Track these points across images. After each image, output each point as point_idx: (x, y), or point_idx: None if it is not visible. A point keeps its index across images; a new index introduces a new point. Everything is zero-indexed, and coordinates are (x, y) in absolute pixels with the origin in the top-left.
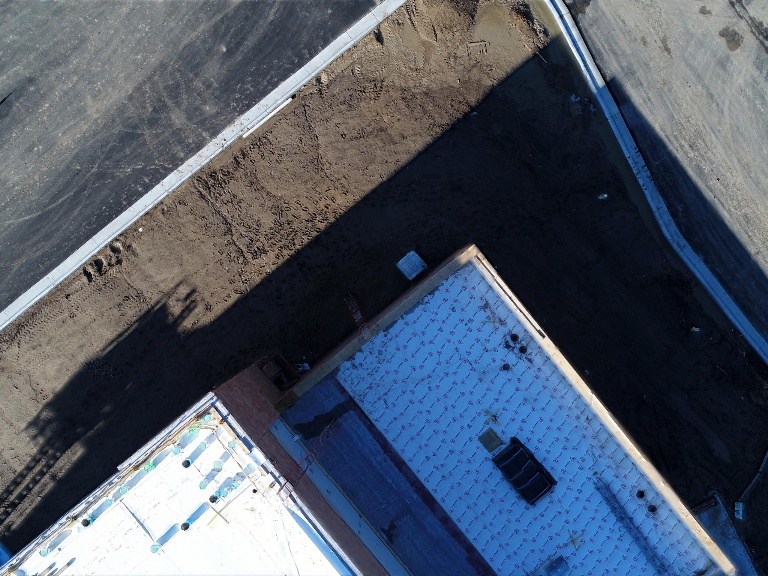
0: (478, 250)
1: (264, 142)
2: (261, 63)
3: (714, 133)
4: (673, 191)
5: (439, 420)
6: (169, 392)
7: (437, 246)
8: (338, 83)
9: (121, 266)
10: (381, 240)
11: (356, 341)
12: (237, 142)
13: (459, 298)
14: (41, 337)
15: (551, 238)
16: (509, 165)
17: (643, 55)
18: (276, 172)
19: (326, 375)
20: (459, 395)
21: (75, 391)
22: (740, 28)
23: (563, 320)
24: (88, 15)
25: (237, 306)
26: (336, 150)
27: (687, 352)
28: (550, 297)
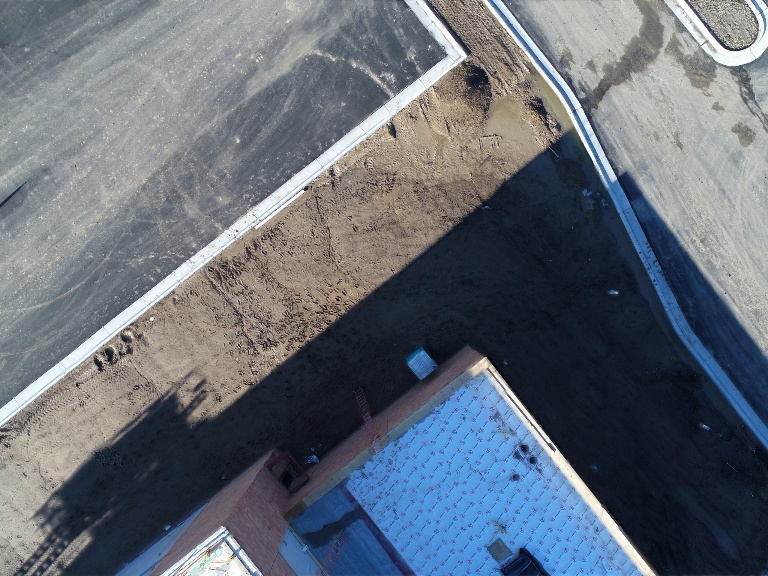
0: (490, 363)
1: (276, 233)
2: (274, 155)
3: (726, 229)
4: (684, 286)
5: (448, 530)
6: (177, 482)
7: (447, 340)
8: (350, 175)
9: (132, 355)
10: (391, 333)
11: (366, 452)
12: (249, 233)
13: (470, 408)
14: (51, 425)
15: (561, 333)
16: (520, 259)
17: (655, 150)
18: (287, 264)
19: (336, 484)
20: (469, 505)
21: (84, 480)
22: (752, 124)
23: (573, 415)
24: (103, 106)
25: (247, 397)
26: (348, 243)
27: (697, 449)
28: (560, 392)
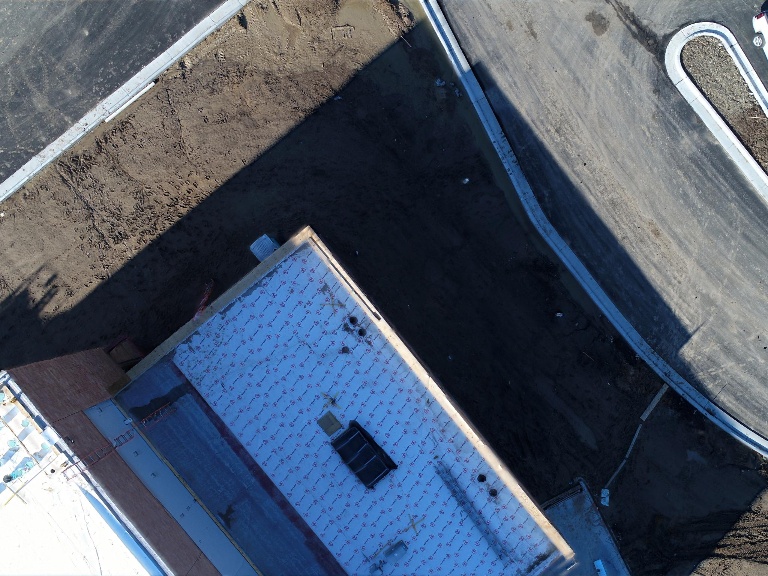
0: (313, 231)
1: (126, 126)
2: (124, 47)
3: (580, 118)
4: (539, 176)
5: (277, 403)
6: None
7: None
8: (201, 67)
9: None
10: (243, 225)
11: (190, 323)
12: (100, 127)
13: (298, 280)
14: None
15: (415, 223)
16: (373, 150)
17: (509, 39)
18: (138, 157)
19: (162, 358)
20: (298, 378)
21: None
22: (606, 13)
23: (428, 306)
24: None
25: (98, 291)
26: (198, 134)
27: (553, 338)
28: (414, 282)
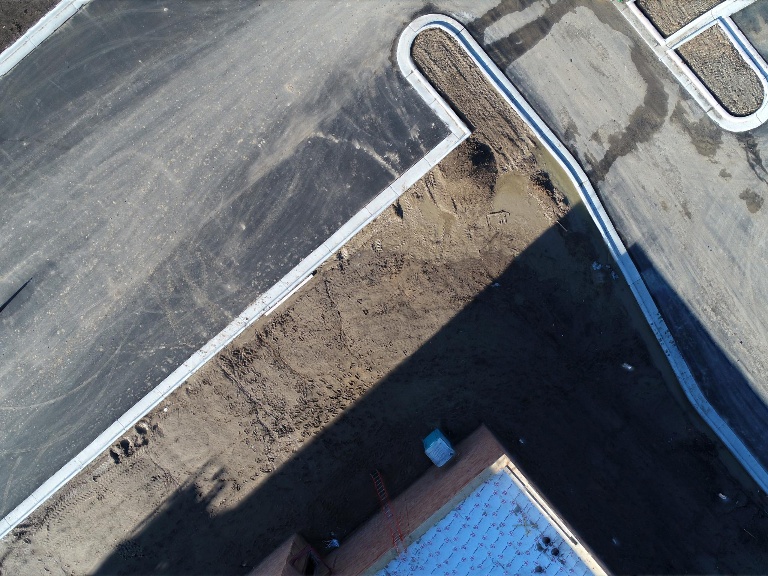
0: (508, 460)
1: (286, 319)
2: (281, 240)
3: (736, 296)
4: (696, 355)
5: None
6: (199, 571)
7: (462, 420)
8: (359, 258)
9: (147, 446)
10: (406, 415)
11: (389, 553)
12: (259, 320)
13: (490, 503)
14: (70, 519)
15: (576, 407)
16: (532, 335)
17: (663, 220)
18: (299, 350)
19: None
20: None
21: (106, 572)
22: (760, 190)
23: (589, 488)
24: (106, 198)
25: (264, 484)
26: (359, 326)
27: (714, 516)
28: (576, 466)
